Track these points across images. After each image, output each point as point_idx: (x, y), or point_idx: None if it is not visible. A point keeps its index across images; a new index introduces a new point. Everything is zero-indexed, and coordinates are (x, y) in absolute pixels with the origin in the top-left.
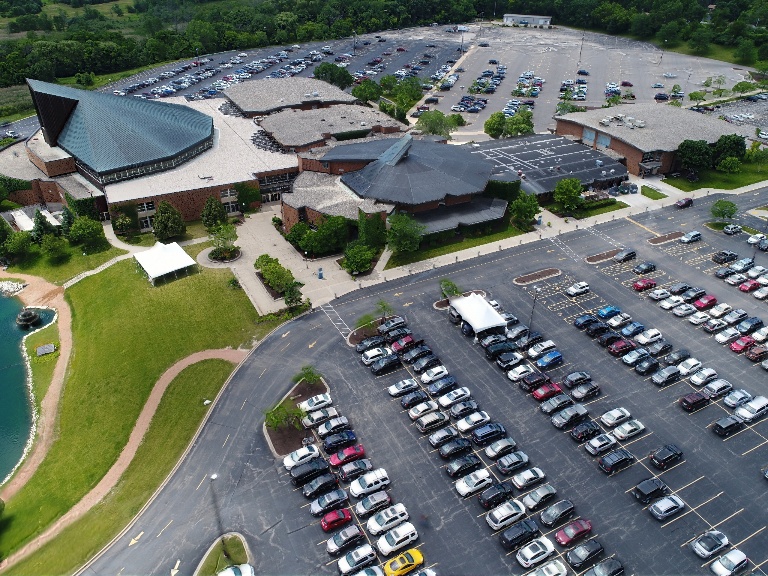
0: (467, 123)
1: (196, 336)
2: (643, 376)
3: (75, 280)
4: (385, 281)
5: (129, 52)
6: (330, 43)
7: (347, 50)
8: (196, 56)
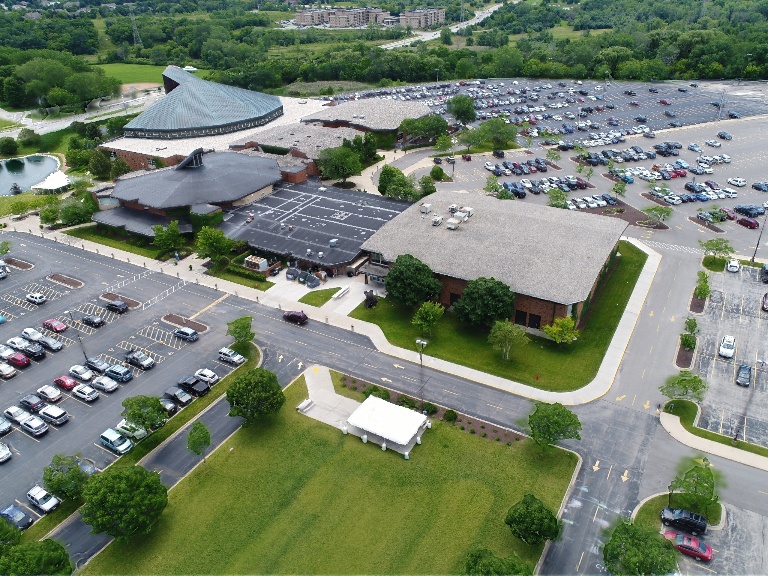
0: None
1: None
2: None
3: None
4: (42, 236)
5: (438, 67)
6: None
7: None
8: None
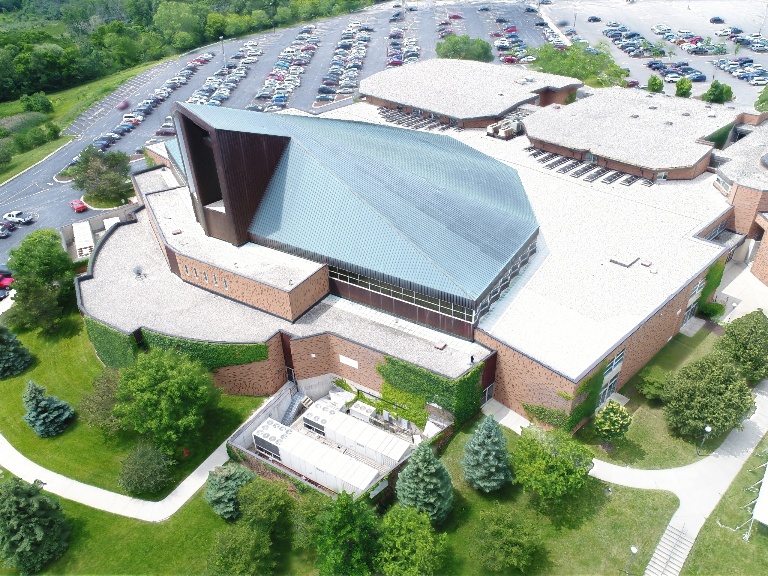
0: (733, 96)
1: None
2: None
3: None
4: None
5: None
6: (353, 18)
7: (384, 24)
8: (181, 52)
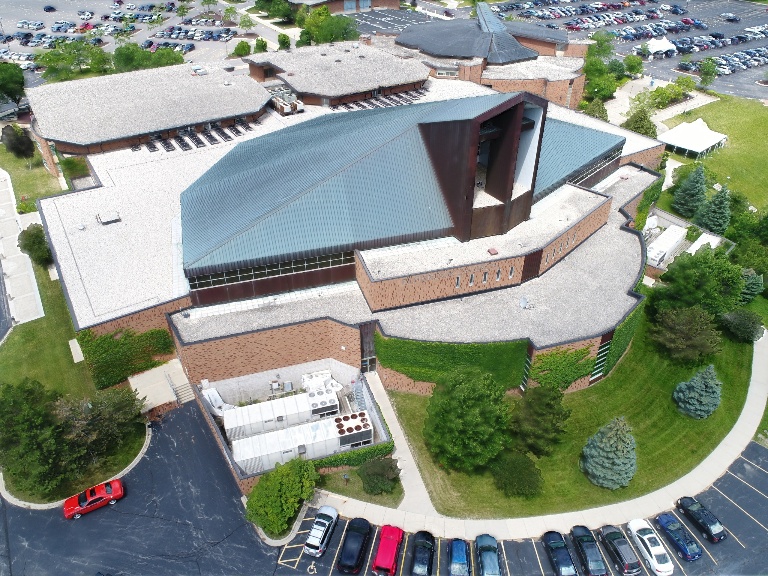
0: None
1: (767, 116)
2: (662, 35)
3: None
4: None
5: None
6: None
7: None
8: None
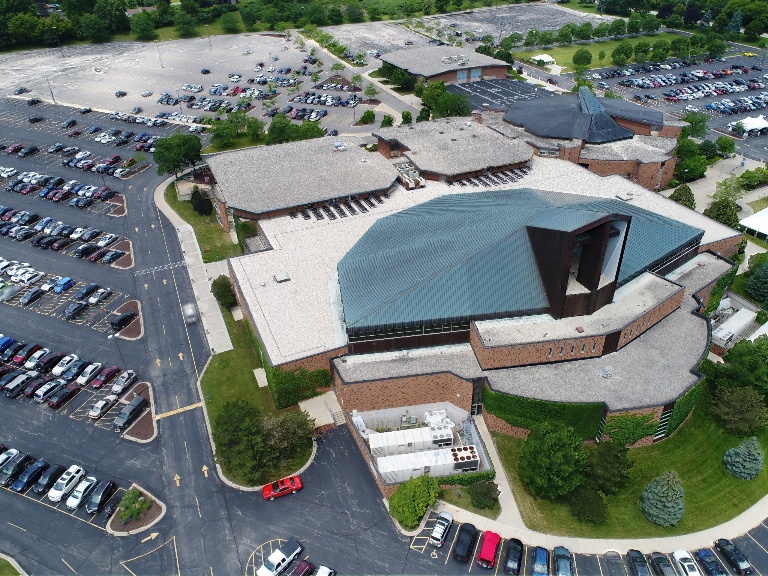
0: None
1: None
2: None
3: None
4: None
5: None
6: None
7: None
8: None
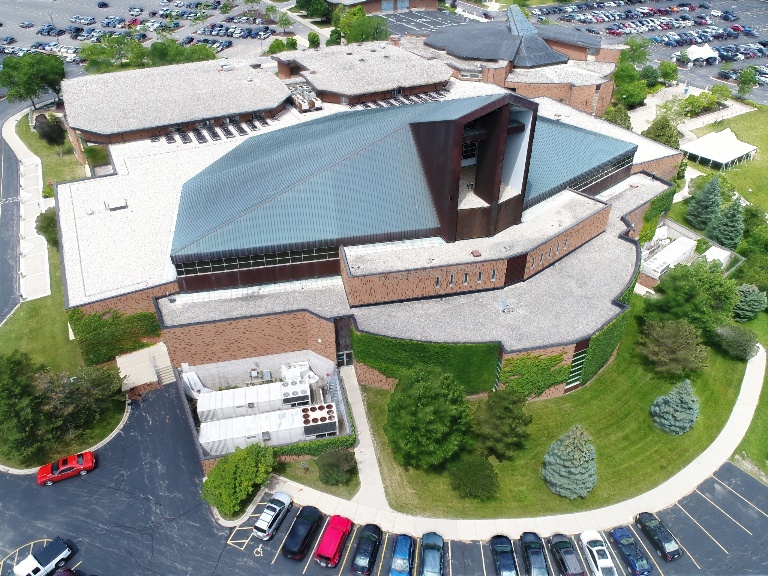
0: None
1: None
2: (707, 42)
3: (767, 217)
4: None
5: None
6: None
7: None
8: None
